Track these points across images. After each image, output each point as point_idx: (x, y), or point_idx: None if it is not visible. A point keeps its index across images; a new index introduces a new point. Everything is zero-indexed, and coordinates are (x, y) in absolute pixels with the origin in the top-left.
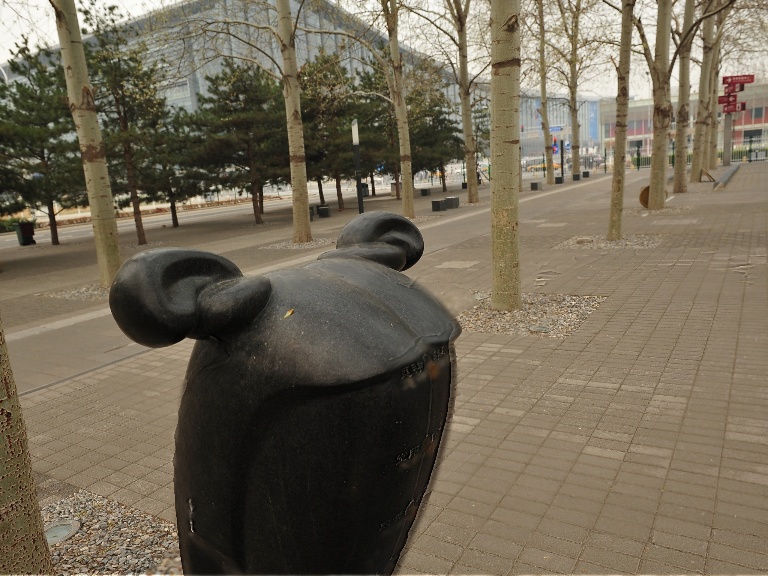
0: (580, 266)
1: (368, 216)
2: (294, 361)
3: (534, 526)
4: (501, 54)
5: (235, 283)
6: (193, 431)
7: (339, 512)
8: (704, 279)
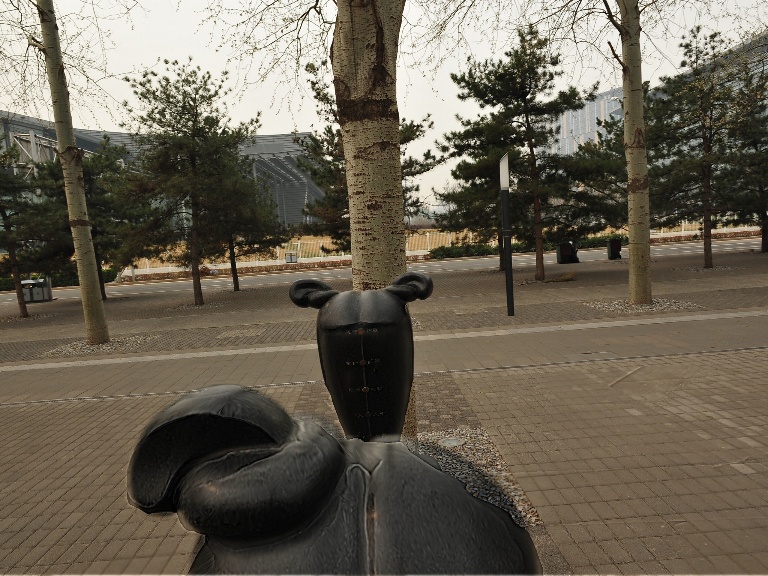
0: None
1: None
2: None
3: None
4: None
5: (319, 292)
6: None
7: None
8: None
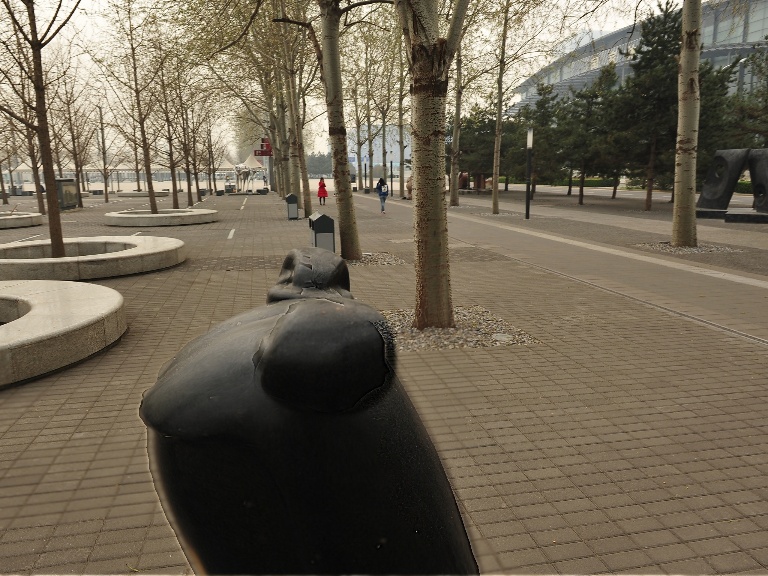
0: None
1: None
2: None
3: None
4: None
5: None
6: None
7: None
8: None
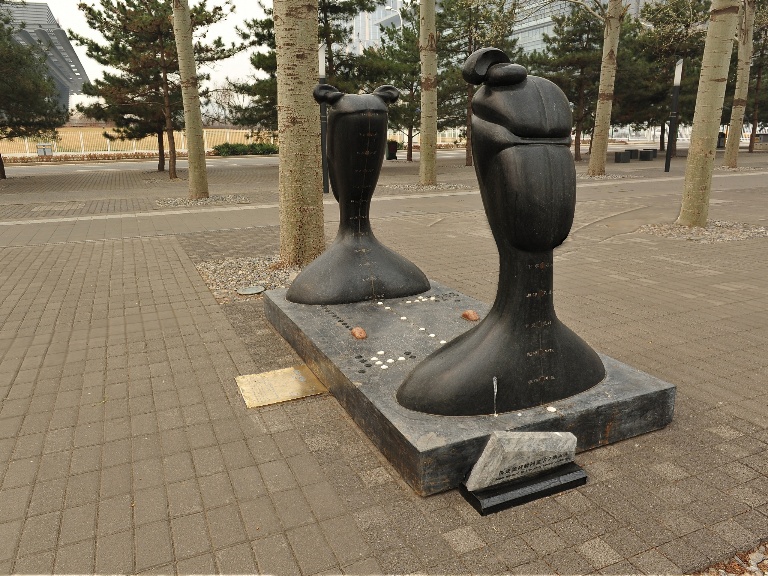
0: None
1: None
2: (340, 108)
3: None
4: (720, 3)
5: None
6: None
7: (347, 145)
8: None
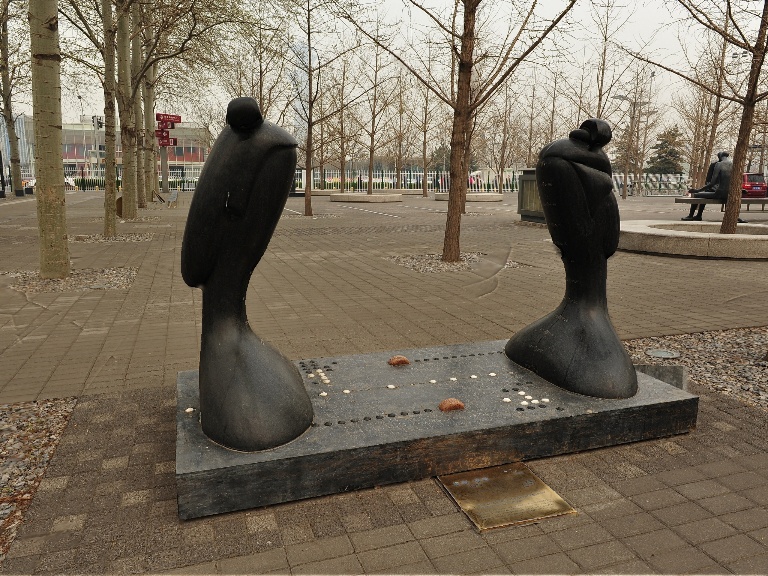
0: (95, 252)
1: None
2: None
3: (196, 351)
4: (44, 47)
5: None
6: (236, 164)
7: None
8: None
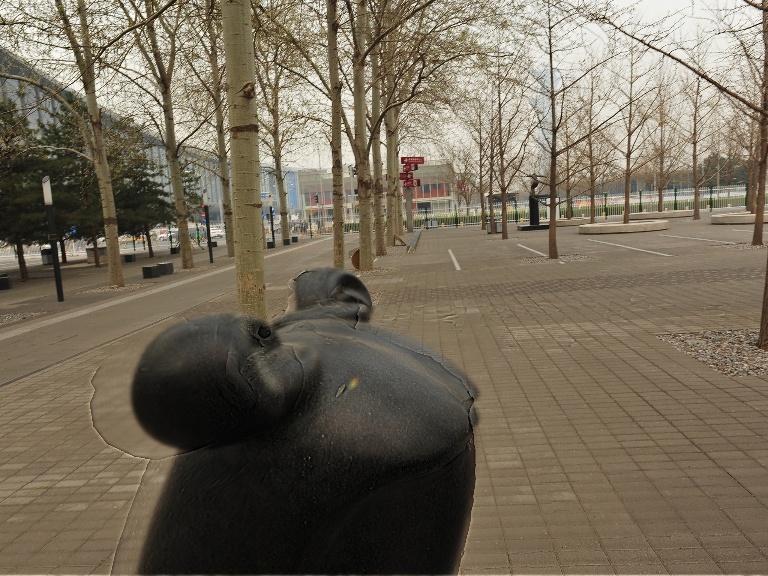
0: None
1: (314, 268)
2: (369, 453)
3: None
4: (238, 118)
5: (273, 356)
6: None
7: None
8: (424, 330)
